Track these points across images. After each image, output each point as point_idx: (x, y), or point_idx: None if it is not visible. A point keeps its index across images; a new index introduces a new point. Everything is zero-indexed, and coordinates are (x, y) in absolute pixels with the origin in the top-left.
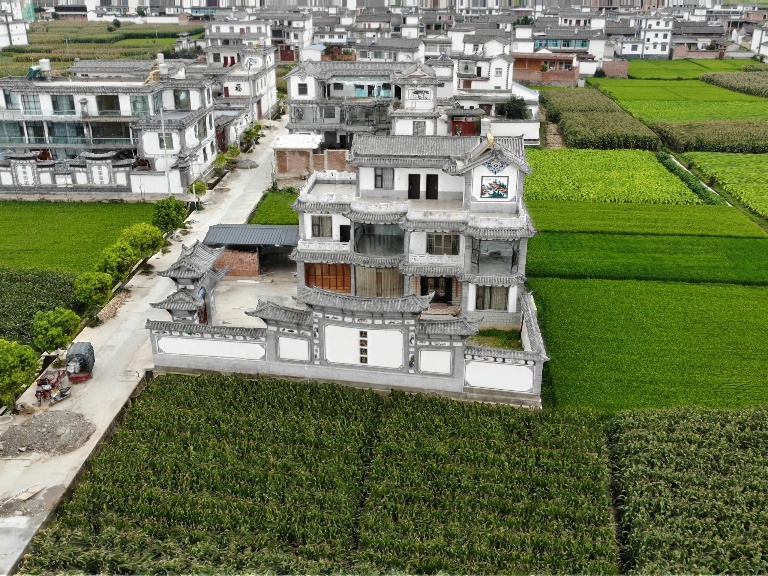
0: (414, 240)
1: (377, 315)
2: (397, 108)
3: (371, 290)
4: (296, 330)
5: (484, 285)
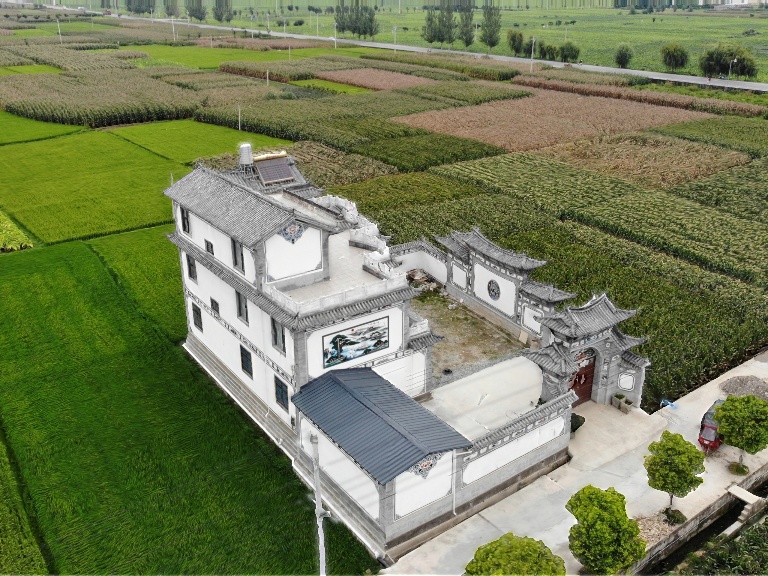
0: None
1: None
2: None
3: None
4: None
5: None
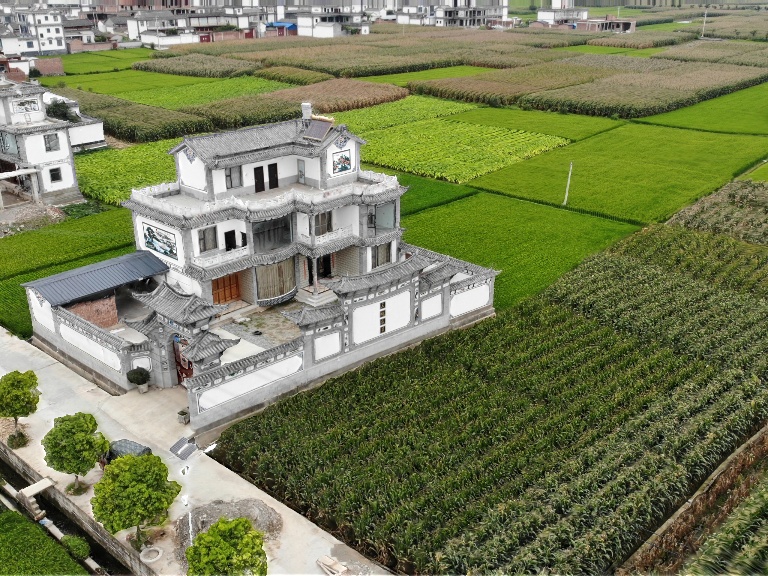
0: (300, 226)
1: (395, 282)
2: (3, 125)
3: (275, 286)
4: (330, 325)
5: (380, 244)
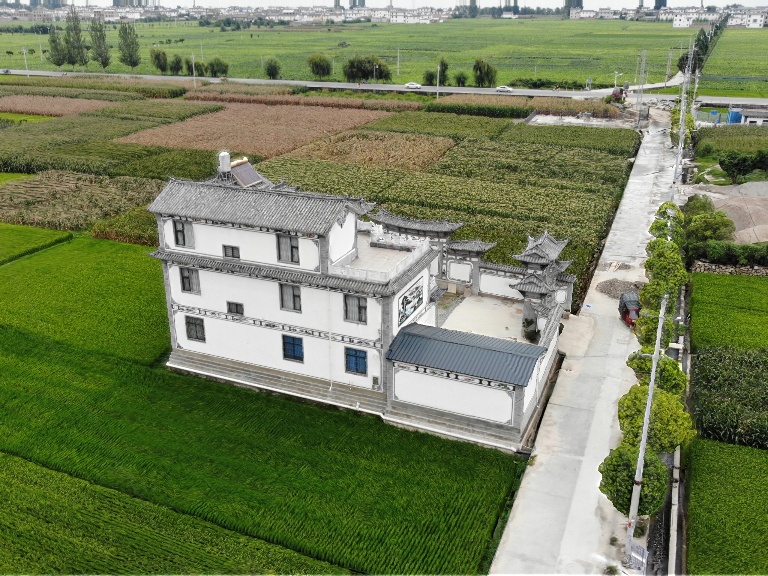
0: None
1: None
2: None
3: None
4: None
5: None
